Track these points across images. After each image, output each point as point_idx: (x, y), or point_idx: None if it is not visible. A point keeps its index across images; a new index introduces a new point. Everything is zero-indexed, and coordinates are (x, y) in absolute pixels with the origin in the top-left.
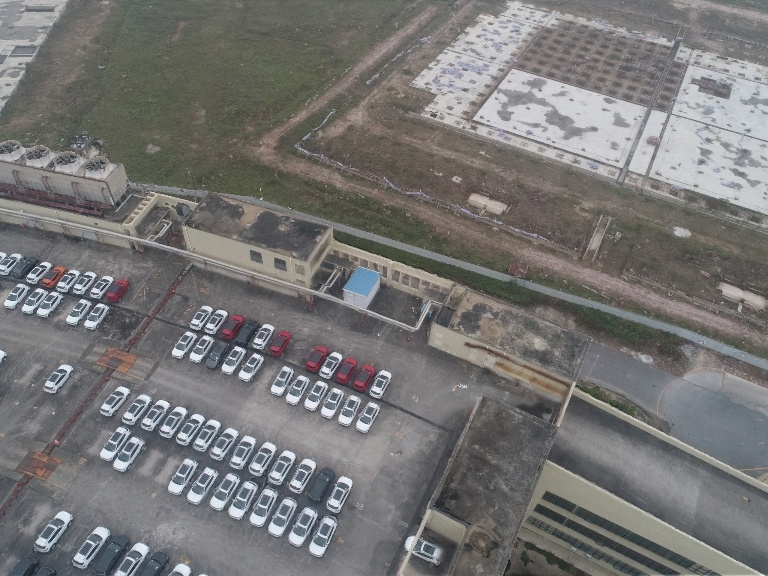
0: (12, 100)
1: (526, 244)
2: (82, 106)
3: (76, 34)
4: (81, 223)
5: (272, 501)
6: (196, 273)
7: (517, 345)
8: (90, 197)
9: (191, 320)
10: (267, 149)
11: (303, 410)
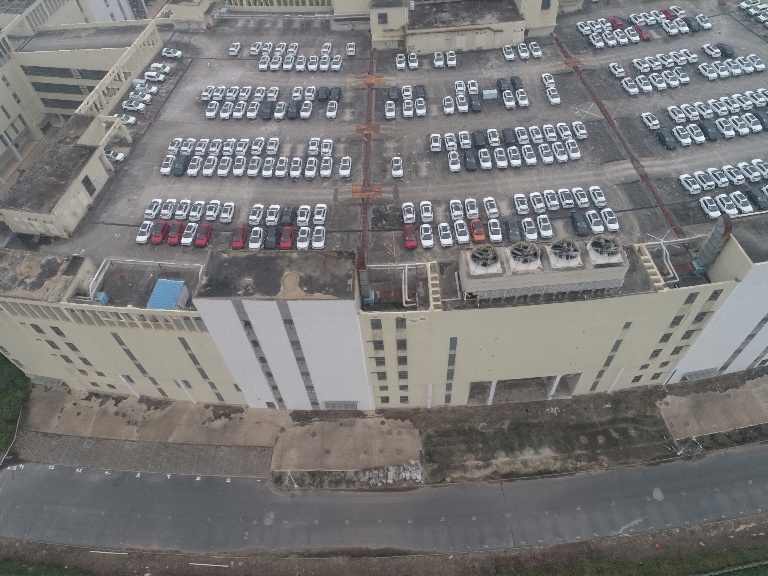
0: None
1: None
2: None
3: None
4: None
5: None
6: None
7: (8, 261)
8: None
9: None
10: None
11: None
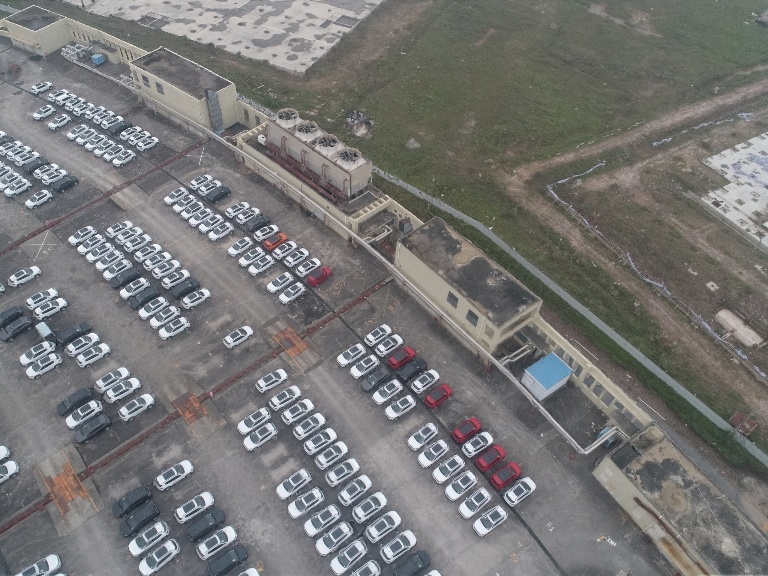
0: (319, 62)
1: (767, 395)
2: (371, 85)
3: (395, 17)
4: (317, 202)
5: (359, 556)
6: (393, 288)
7: (699, 533)
8: (333, 182)
9: (368, 333)
10: (518, 180)
11: (429, 477)
